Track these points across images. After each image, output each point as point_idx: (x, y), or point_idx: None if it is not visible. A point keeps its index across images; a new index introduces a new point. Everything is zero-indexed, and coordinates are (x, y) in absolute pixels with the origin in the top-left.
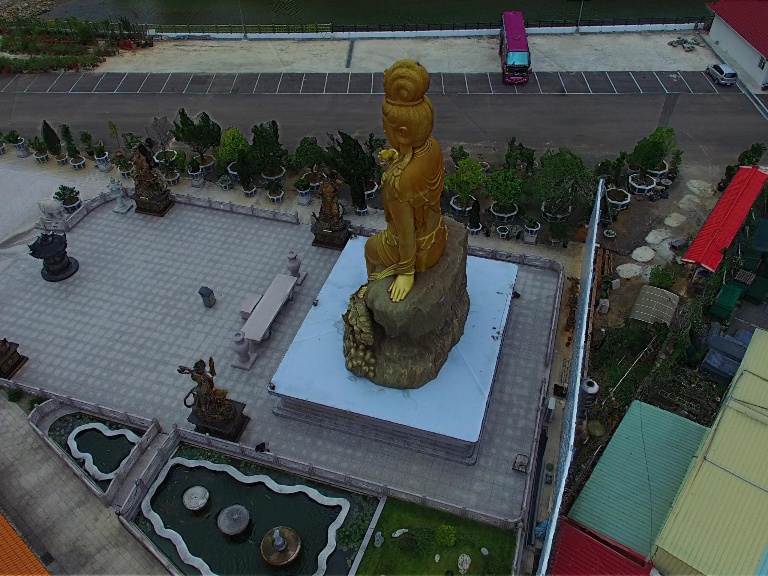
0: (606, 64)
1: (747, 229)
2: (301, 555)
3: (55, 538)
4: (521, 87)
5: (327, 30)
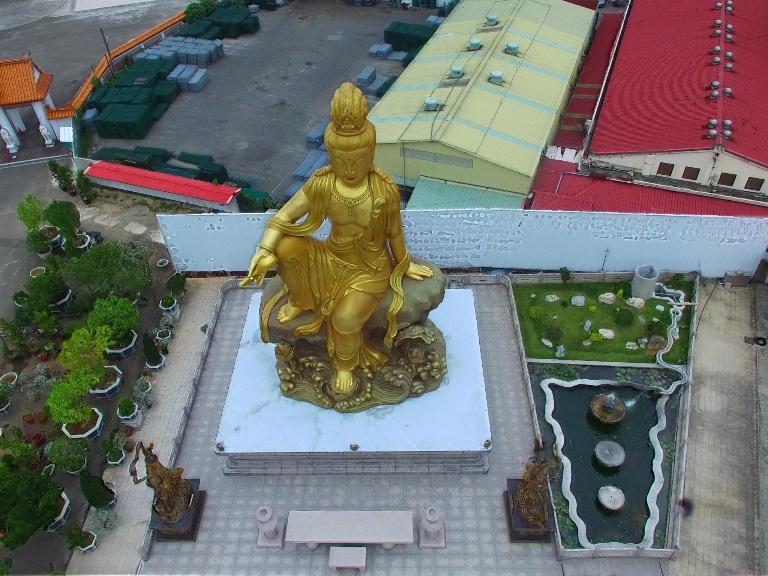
0: None
1: None
2: None
3: None
4: None
5: None
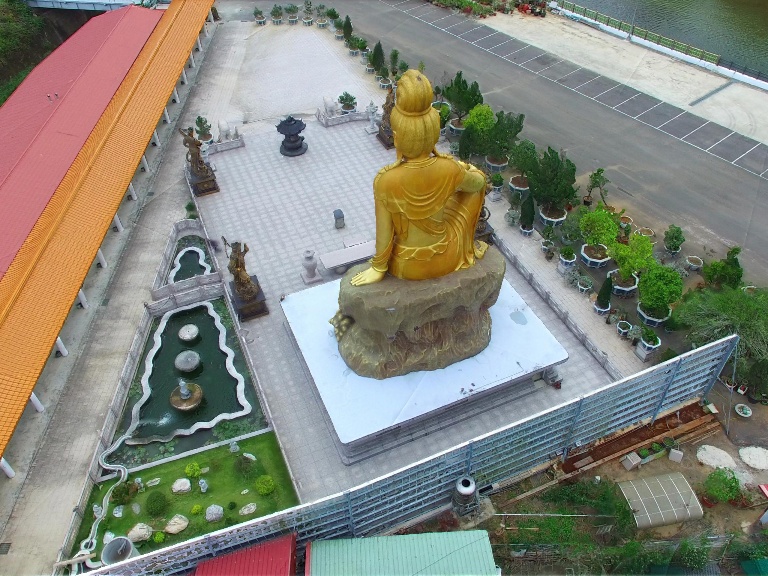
0: None
1: None
2: (192, 413)
3: (120, 295)
4: None
5: (713, 61)
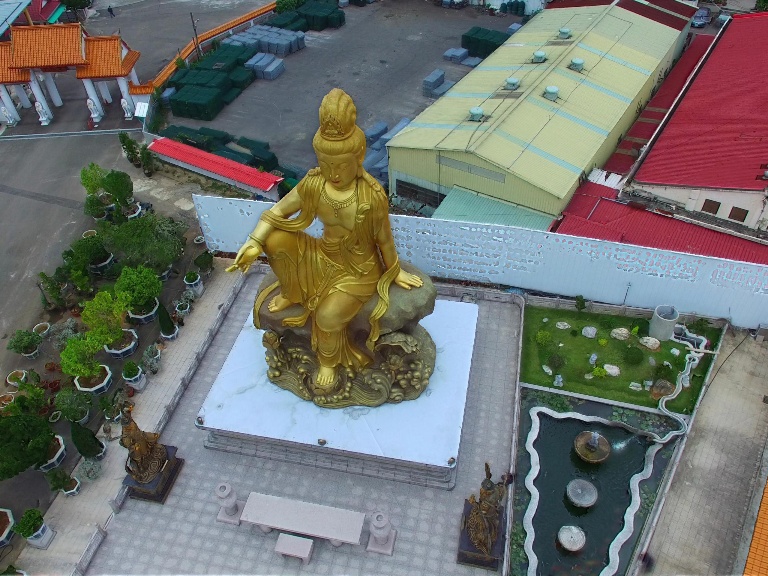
0: None
1: None
2: None
3: None
4: None
5: None
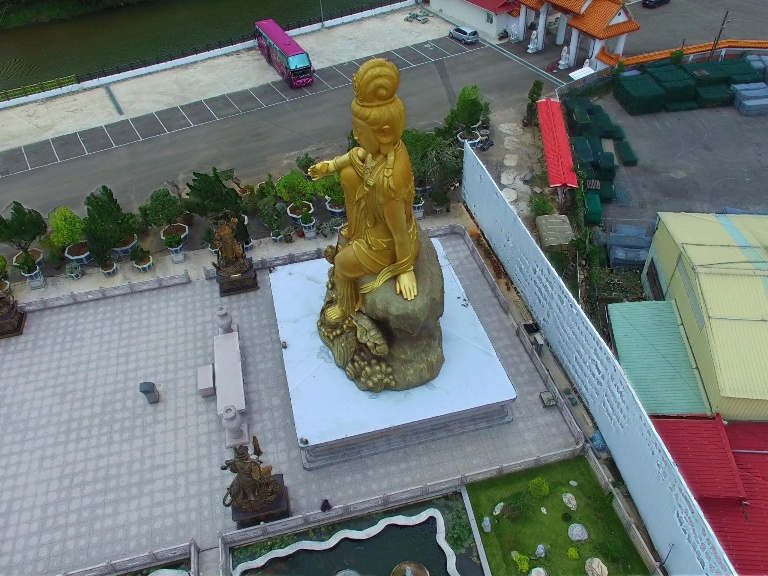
0: (367, 49)
1: (573, 148)
2: None
3: None
4: (310, 88)
5: (72, 82)
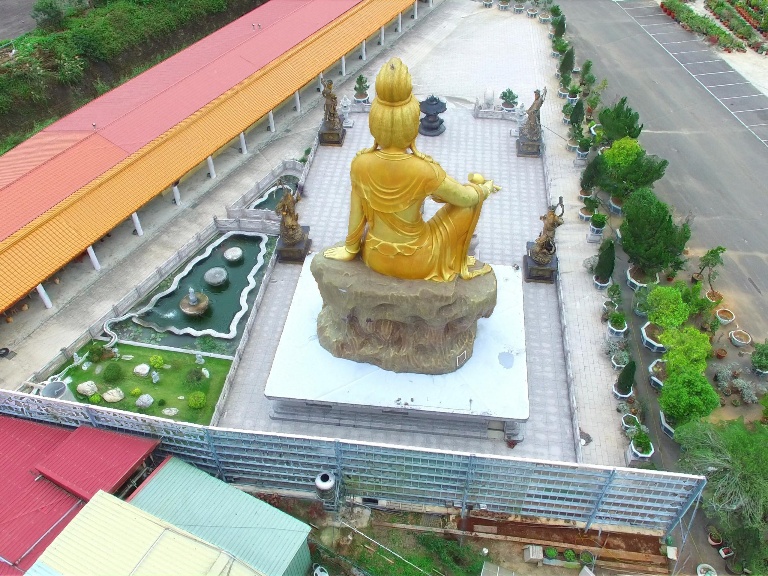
0: None
1: None
2: (191, 318)
3: (208, 204)
4: None
5: None
